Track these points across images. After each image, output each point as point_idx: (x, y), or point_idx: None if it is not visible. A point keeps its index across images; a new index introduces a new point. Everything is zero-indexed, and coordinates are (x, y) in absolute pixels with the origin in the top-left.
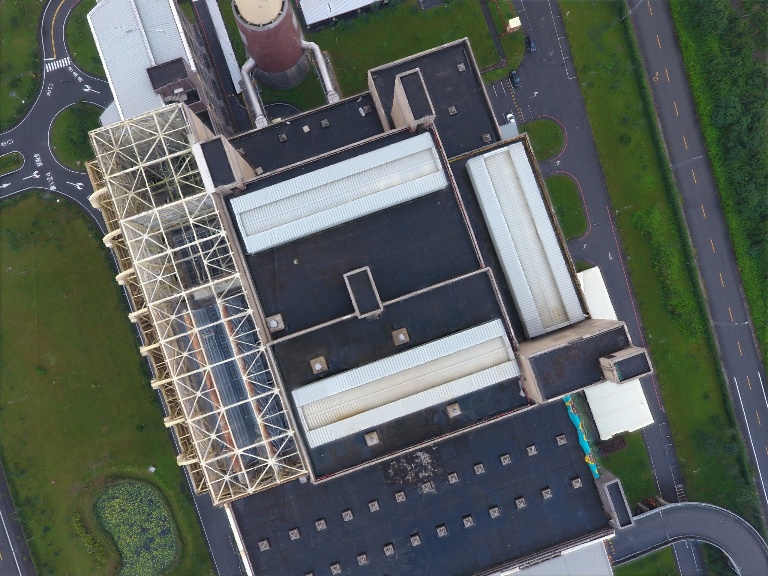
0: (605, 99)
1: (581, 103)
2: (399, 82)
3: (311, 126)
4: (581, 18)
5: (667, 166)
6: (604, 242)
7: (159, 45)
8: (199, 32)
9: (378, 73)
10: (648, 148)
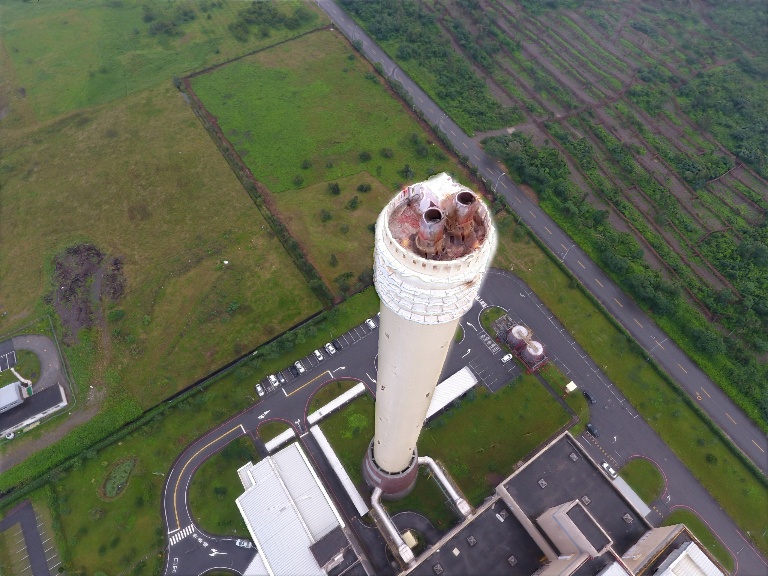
0: (673, 427)
1: (656, 436)
2: (568, 518)
3: (460, 547)
4: (616, 367)
5: (761, 475)
6: (758, 571)
7: (309, 513)
8: (312, 465)
9: (508, 483)
10: (733, 461)
